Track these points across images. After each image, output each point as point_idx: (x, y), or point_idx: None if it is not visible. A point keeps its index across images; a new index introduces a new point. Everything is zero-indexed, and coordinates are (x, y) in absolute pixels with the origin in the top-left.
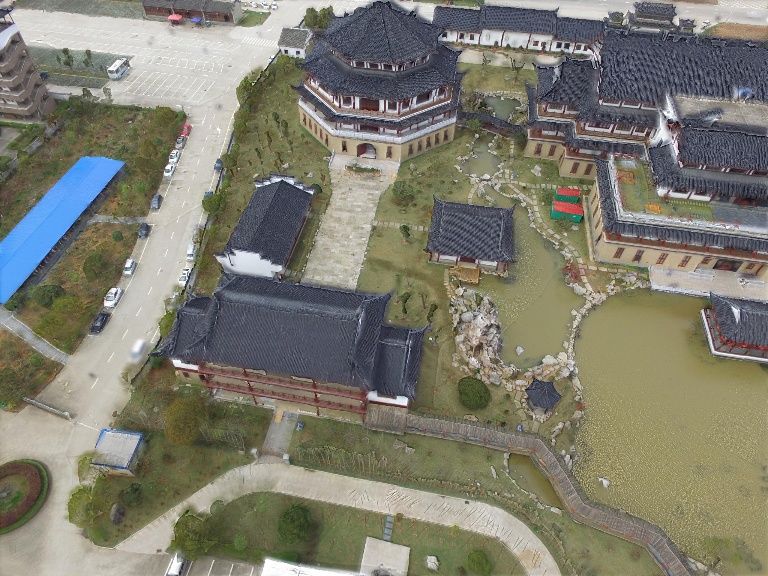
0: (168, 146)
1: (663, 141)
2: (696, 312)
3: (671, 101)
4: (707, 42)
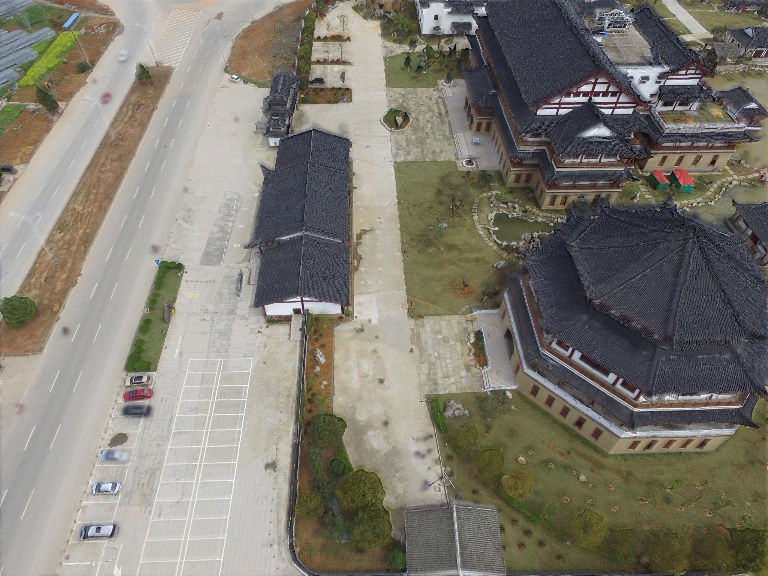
0: None
1: (643, 94)
2: None
3: (639, 68)
4: (307, 79)
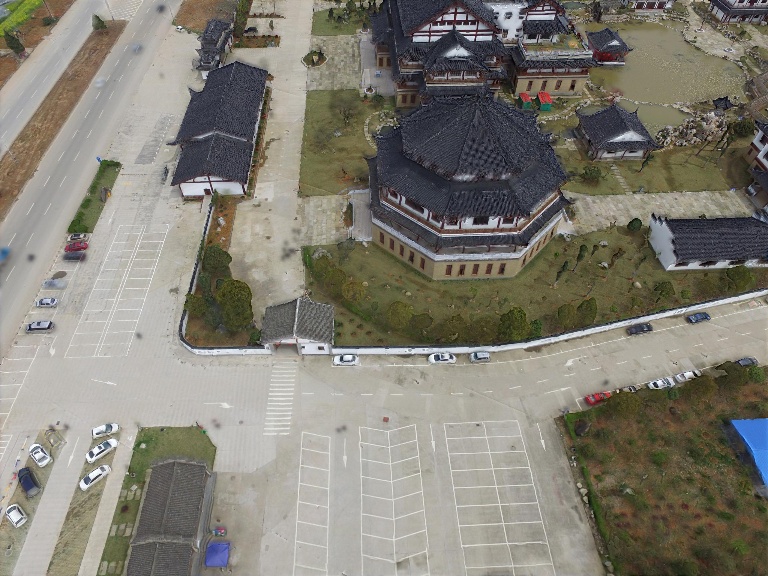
0: (647, 403)
1: (510, 28)
2: (593, 68)
3: (501, 5)
4: (241, 28)
